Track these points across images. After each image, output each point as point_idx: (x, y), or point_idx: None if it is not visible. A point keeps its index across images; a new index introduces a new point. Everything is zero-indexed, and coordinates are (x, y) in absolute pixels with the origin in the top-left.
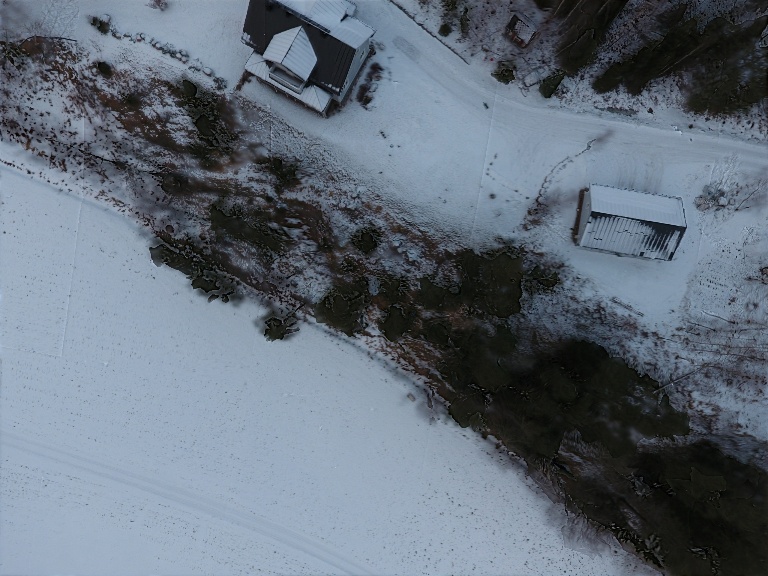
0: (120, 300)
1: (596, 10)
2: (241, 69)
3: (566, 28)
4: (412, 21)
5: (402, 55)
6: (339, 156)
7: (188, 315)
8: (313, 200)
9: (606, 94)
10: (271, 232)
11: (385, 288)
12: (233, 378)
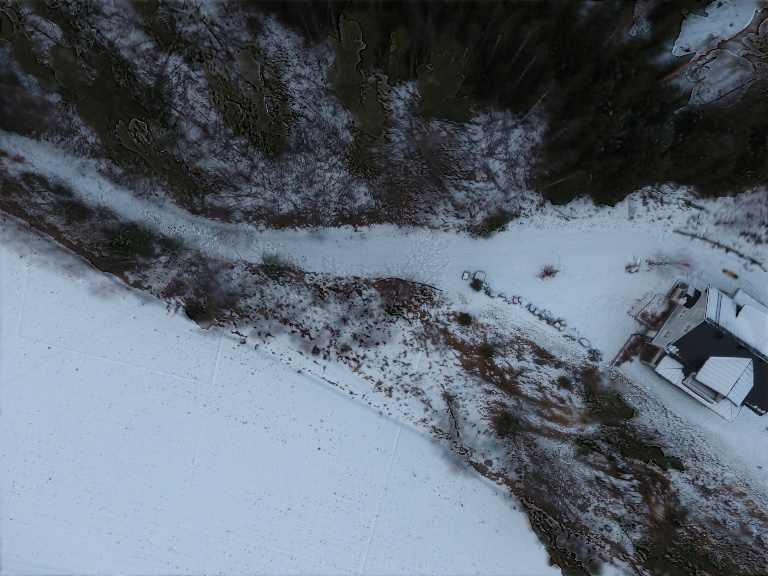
0: (426, 524)
1: None
2: (619, 343)
3: None
4: None
5: None
6: (715, 444)
7: (492, 544)
8: None
9: None
10: (595, 479)
11: (725, 562)
12: None
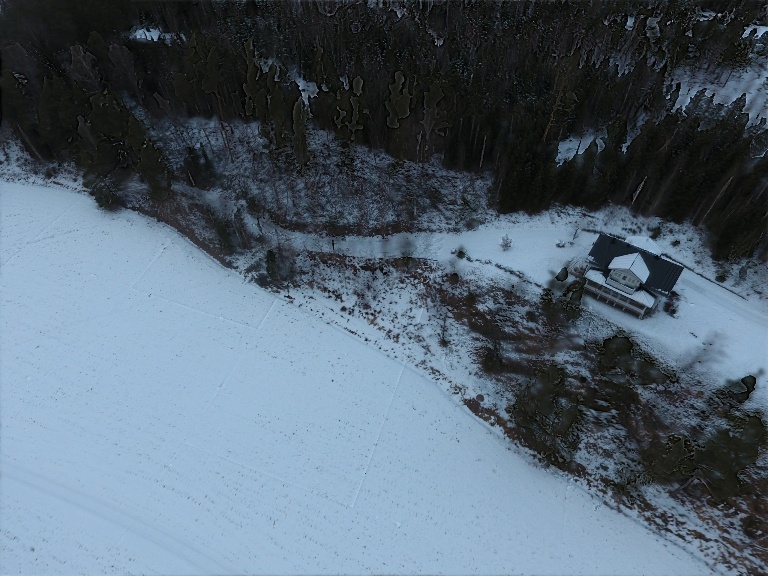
0: (423, 457)
1: None
2: (563, 286)
3: None
4: (692, 272)
5: (691, 289)
6: (656, 347)
7: (490, 485)
8: None
9: None
10: (578, 413)
11: None
12: (542, 570)
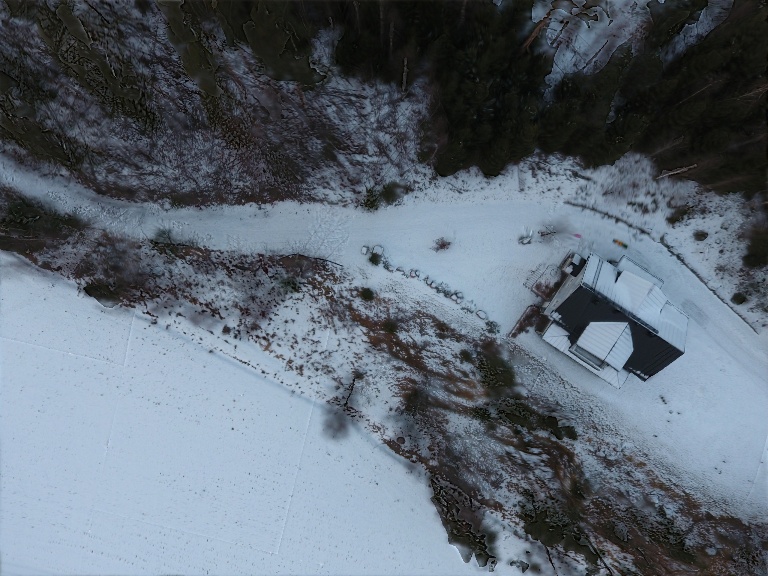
0: (341, 503)
1: None
2: (515, 314)
3: None
4: (703, 285)
5: (690, 319)
6: (611, 414)
7: (408, 523)
8: (567, 442)
9: None
10: (506, 454)
11: (631, 535)
12: None
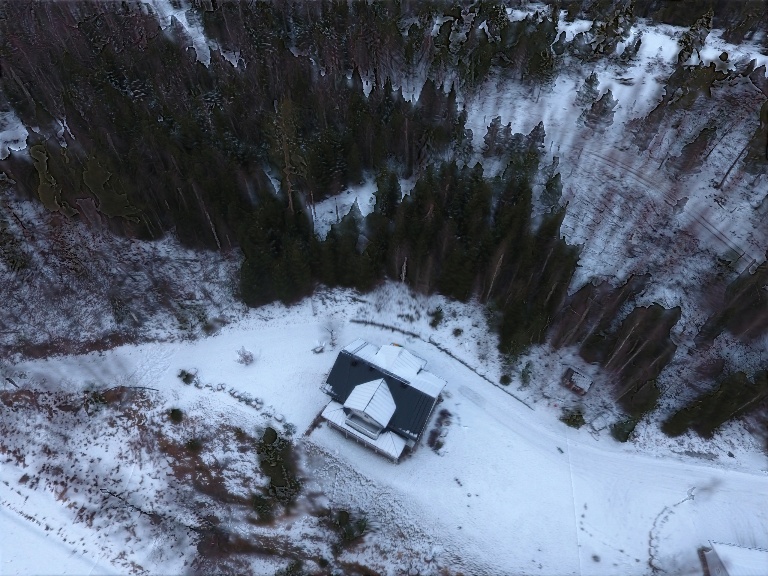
0: None
1: (647, 364)
2: (312, 415)
3: (617, 378)
4: (474, 373)
5: (468, 402)
6: (411, 507)
7: None
8: (377, 564)
9: (678, 438)
10: None
11: None
12: None
